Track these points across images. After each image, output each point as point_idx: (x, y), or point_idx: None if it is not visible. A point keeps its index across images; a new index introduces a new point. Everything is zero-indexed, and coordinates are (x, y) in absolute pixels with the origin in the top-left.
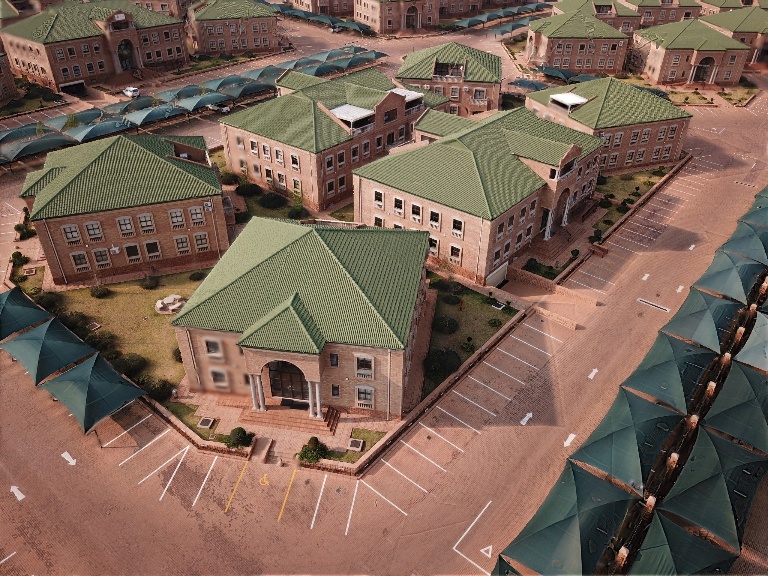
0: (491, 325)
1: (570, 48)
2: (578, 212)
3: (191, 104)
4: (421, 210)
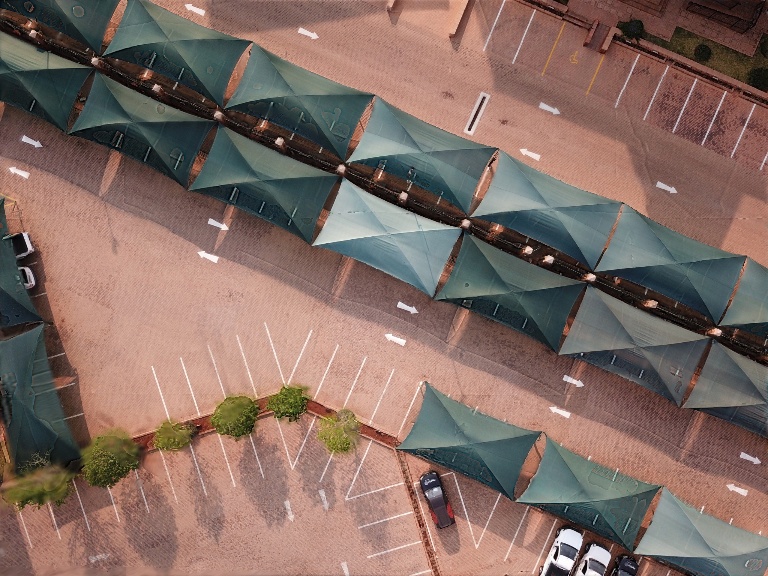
0: None
1: None
2: None
3: None
4: None
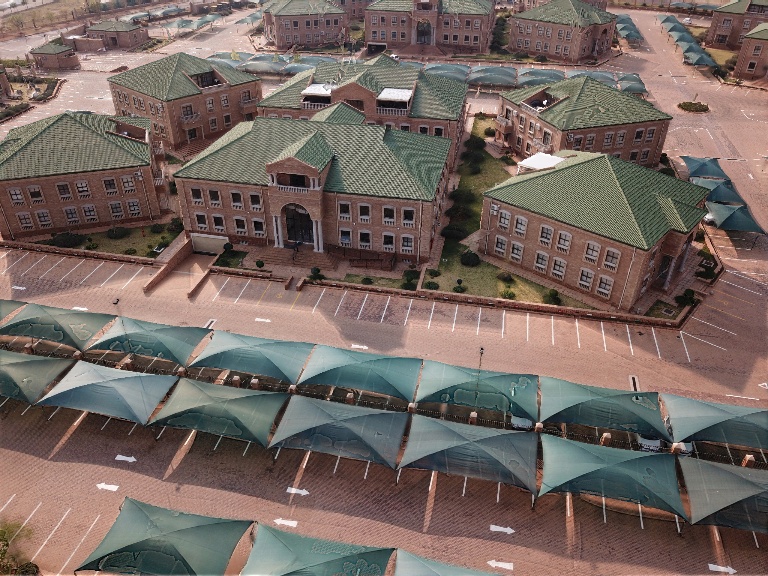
0: (126, 250)
1: None
2: (362, 256)
3: None
4: None
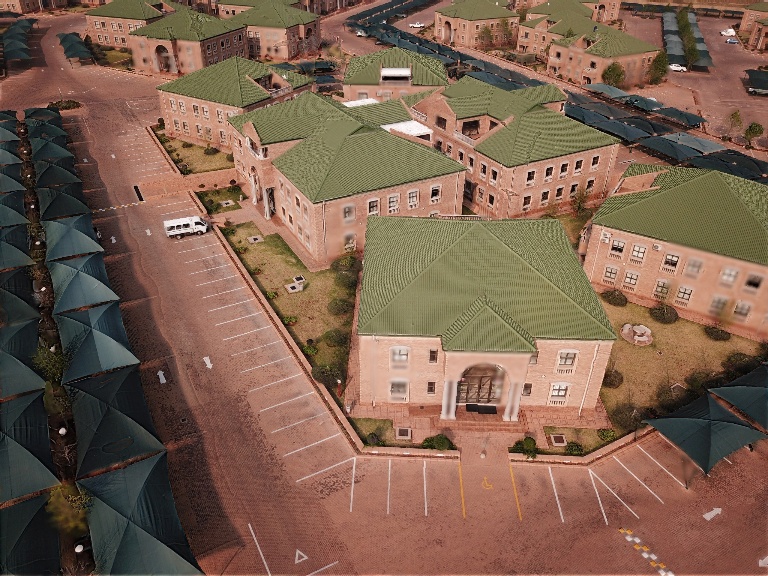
0: None
1: (215, 47)
2: None
3: (80, 245)
4: (569, 165)
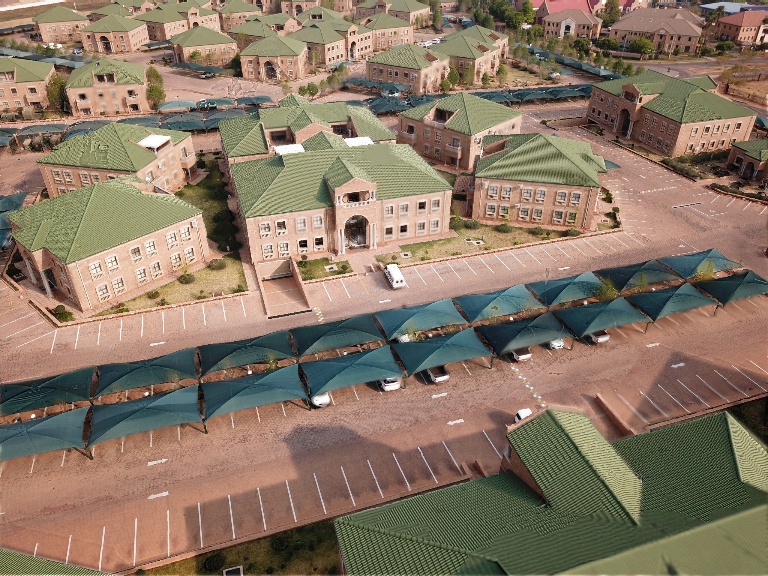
0: None
1: None
2: None
3: (446, 307)
4: None
